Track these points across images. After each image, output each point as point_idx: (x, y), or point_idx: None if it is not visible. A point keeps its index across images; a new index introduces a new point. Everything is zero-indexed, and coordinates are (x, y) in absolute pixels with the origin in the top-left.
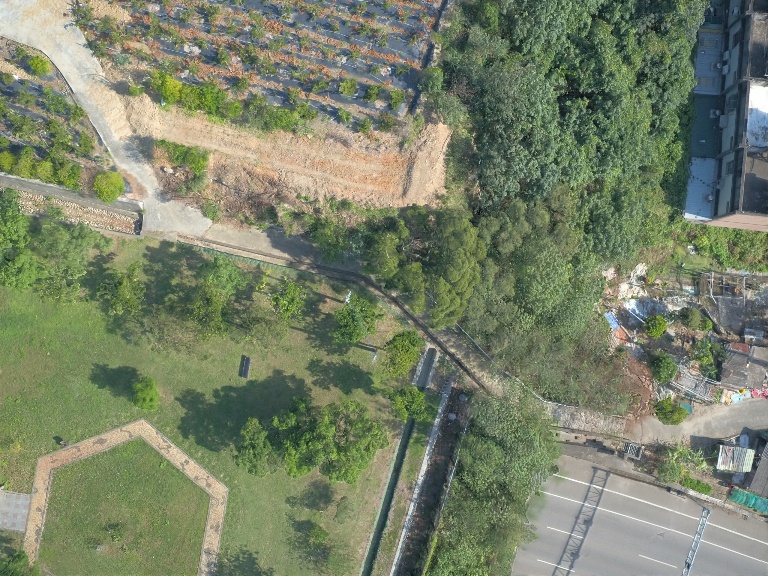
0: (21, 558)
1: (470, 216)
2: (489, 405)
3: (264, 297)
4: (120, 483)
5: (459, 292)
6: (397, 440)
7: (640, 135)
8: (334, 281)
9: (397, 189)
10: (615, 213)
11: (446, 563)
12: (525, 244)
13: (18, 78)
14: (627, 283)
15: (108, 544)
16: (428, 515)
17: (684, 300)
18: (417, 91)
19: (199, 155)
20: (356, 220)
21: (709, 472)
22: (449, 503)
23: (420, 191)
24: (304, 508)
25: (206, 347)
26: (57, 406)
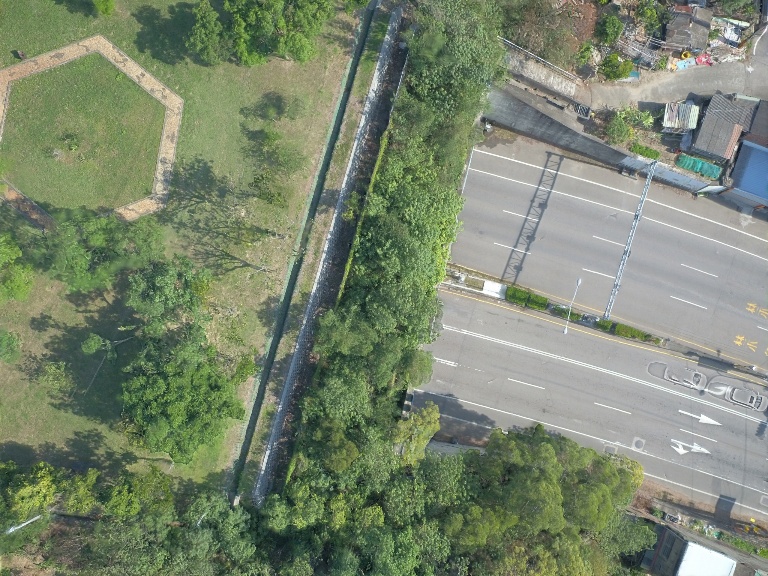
0: None
1: None
2: None
3: None
4: (77, 95)
5: None
6: (348, 57)
7: None
8: None
9: None
10: None
11: (396, 160)
12: None
13: None
14: None
15: (65, 153)
16: None
17: None
18: None
19: None
20: None
21: (657, 139)
22: (398, 103)
23: None
24: (258, 119)
25: None
26: (15, 21)
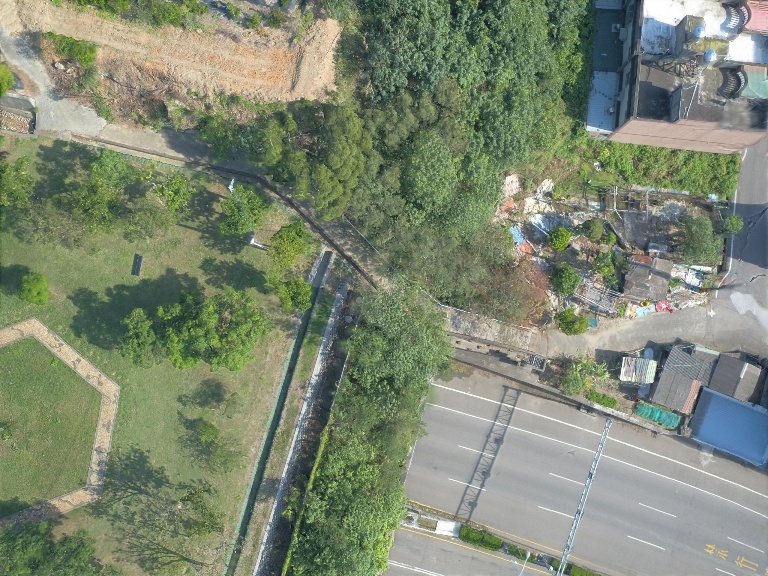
0: None
1: (355, 107)
2: None
3: None
4: (11, 381)
5: (342, 180)
6: (291, 340)
7: (532, 38)
8: (228, 181)
9: (286, 84)
10: (505, 111)
11: (336, 458)
12: (415, 141)
13: None
14: (533, 198)
15: None
16: (324, 417)
17: (590, 215)
18: None
19: (86, 46)
20: (247, 116)
21: (615, 386)
22: (339, 398)
23: (308, 85)
24: (196, 406)
25: (94, 241)
26: None
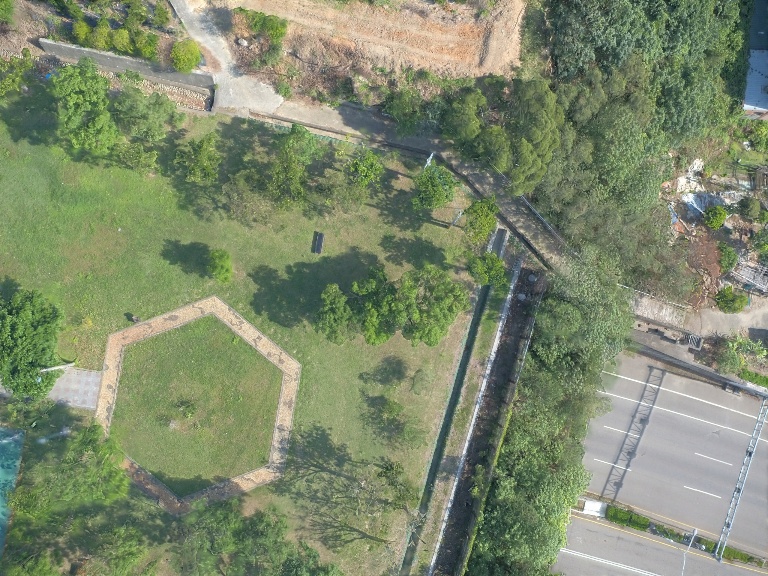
0: (97, 428)
1: (549, 82)
2: (564, 277)
3: None
4: (192, 359)
5: (540, 154)
6: (469, 317)
7: (708, 14)
8: (406, 158)
9: (473, 59)
10: (687, 87)
11: (522, 434)
12: (599, 116)
13: None
14: (685, 177)
15: (181, 420)
16: (499, 395)
17: (741, 195)
18: None
19: (277, 21)
20: (431, 92)
21: (767, 365)
22: (525, 375)
23: (497, 60)
24: (378, 384)
25: (282, 217)
26: (128, 282)
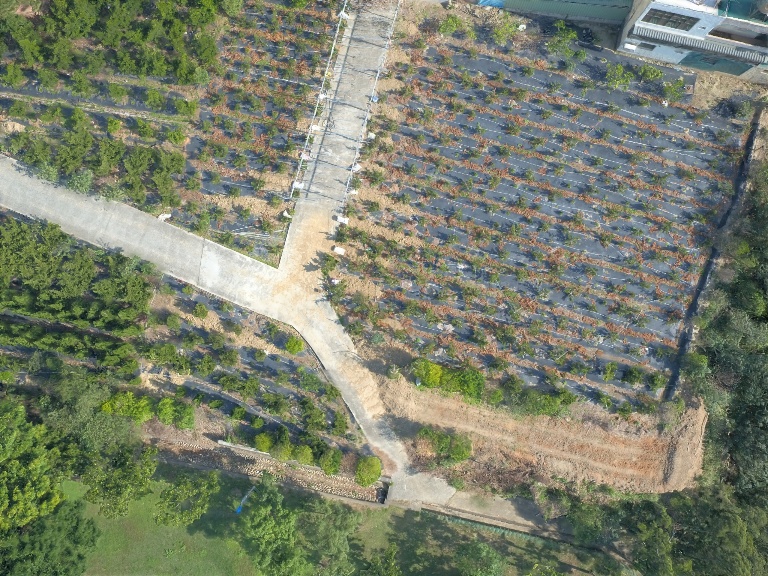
0: None
1: (739, 511)
2: None
3: (509, 567)
4: None
5: None
6: None
7: None
8: (579, 550)
9: (657, 474)
10: None
11: None
12: None
13: (268, 353)
14: None
15: None
16: None
17: None
18: (675, 372)
19: (463, 445)
20: (610, 499)
21: None
22: None
23: (682, 478)
24: None
25: None
26: None
